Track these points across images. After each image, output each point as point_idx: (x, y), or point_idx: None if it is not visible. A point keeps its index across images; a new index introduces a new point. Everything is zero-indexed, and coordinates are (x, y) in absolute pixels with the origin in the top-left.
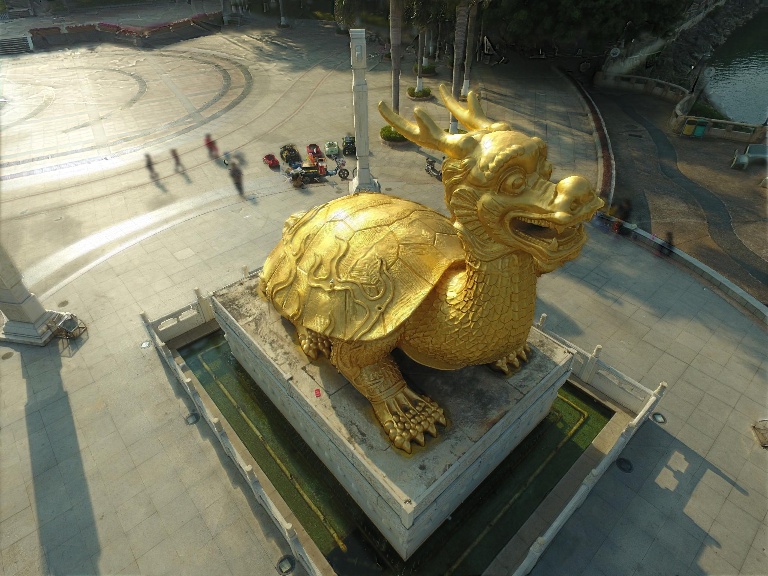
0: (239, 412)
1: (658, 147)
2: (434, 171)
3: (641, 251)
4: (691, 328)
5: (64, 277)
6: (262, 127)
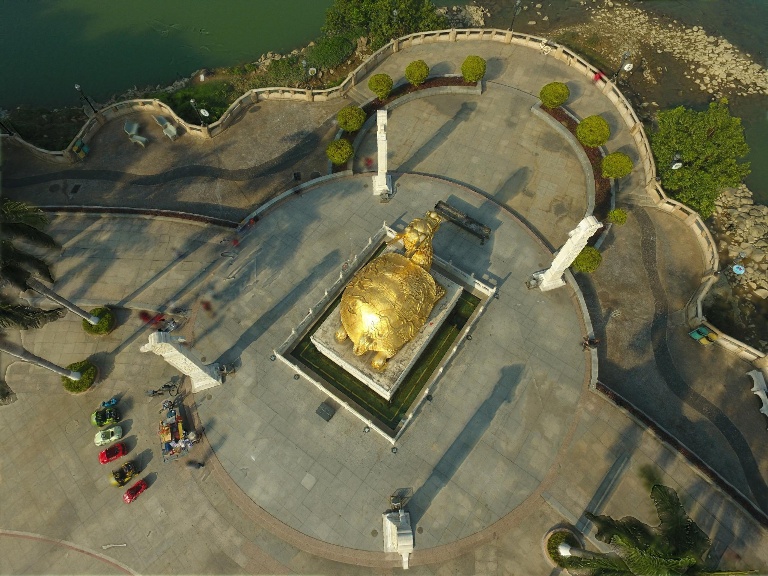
0: (417, 383)
1: (104, 179)
2: (168, 331)
3: (273, 215)
4: (332, 208)
5: (341, 572)
6: (20, 556)
